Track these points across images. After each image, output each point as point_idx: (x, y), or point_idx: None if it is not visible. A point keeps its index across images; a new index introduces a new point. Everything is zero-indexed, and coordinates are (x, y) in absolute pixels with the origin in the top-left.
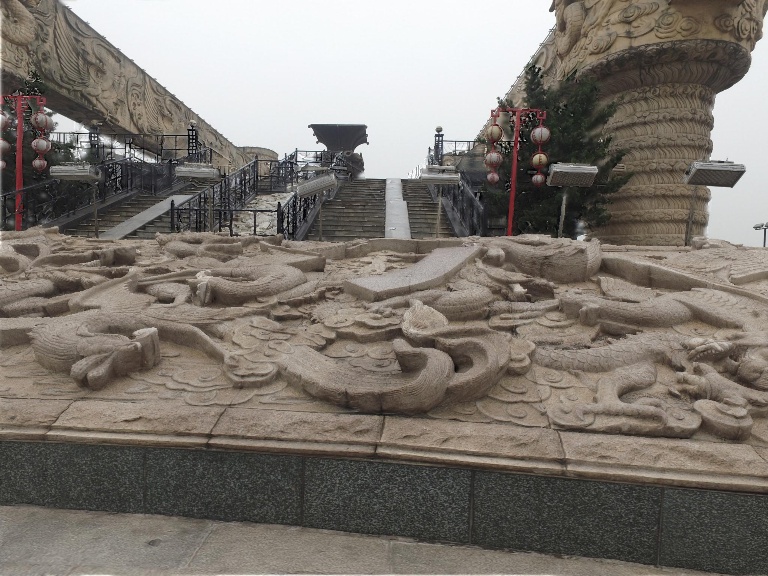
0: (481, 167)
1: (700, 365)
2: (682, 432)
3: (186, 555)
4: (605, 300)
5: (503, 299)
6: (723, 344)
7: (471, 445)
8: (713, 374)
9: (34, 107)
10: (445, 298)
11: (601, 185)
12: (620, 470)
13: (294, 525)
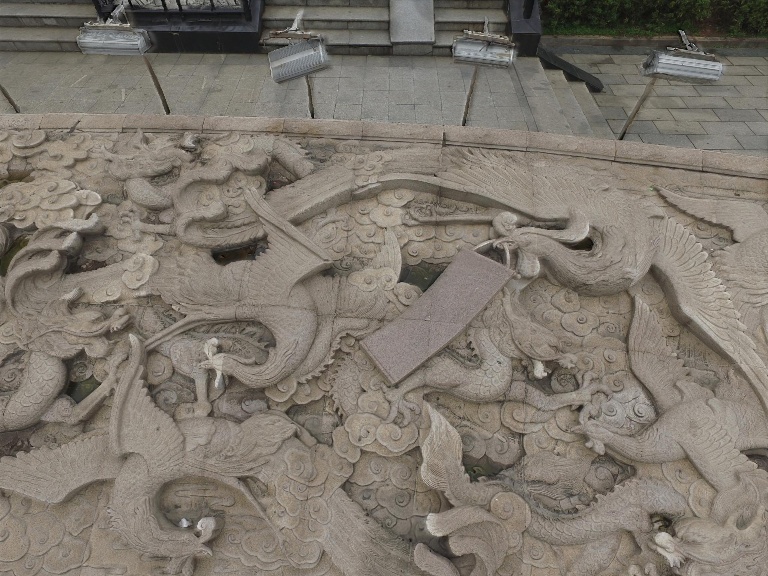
0: None
1: (650, 571)
2: None
3: None
4: (614, 437)
5: (522, 369)
6: (677, 564)
7: None
8: None
9: None
10: (463, 389)
11: None
12: None
13: None
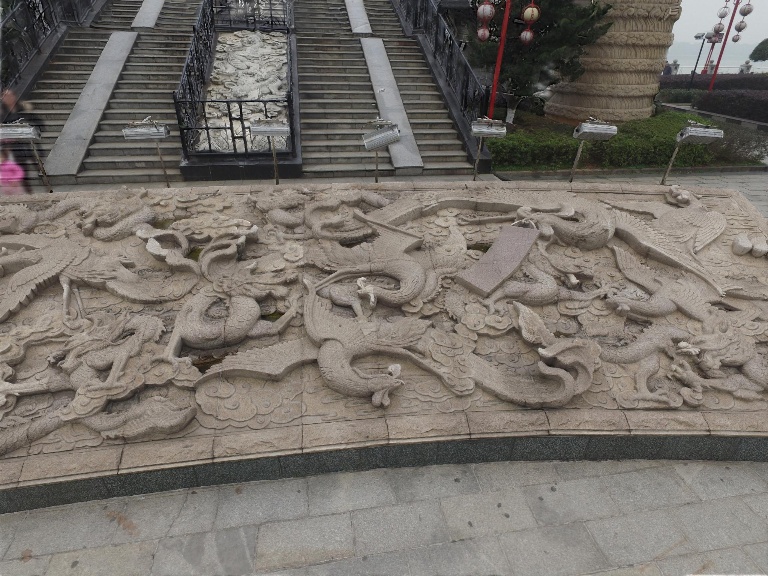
0: (465, 6)
1: (683, 363)
2: (675, 408)
3: (476, 485)
4: (632, 301)
5: (562, 284)
6: (696, 351)
7: (590, 426)
8: (690, 372)
9: None
10: (531, 293)
11: (581, 36)
12: (651, 432)
13: (507, 461)
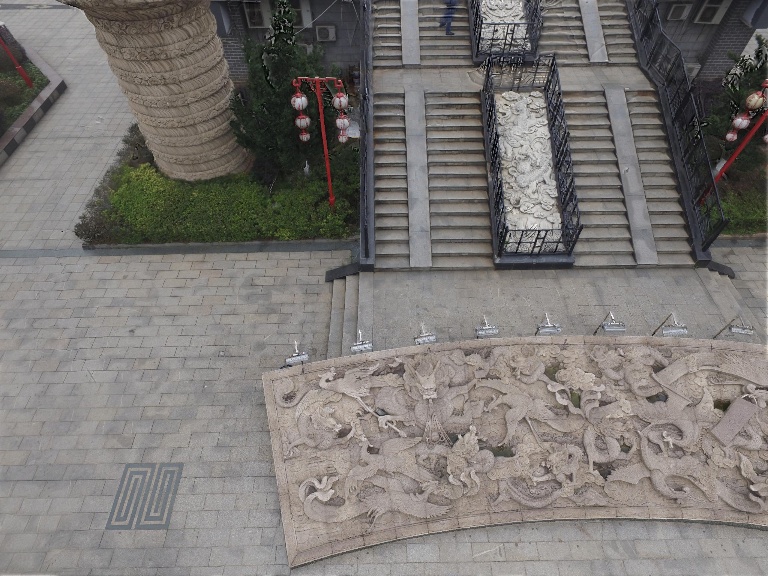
0: (718, 85)
1: None
2: None
3: None
4: None
5: (764, 439)
6: None
7: (766, 523)
8: None
9: (332, 89)
10: (748, 447)
11: None
12: None
13: (724, 525)
